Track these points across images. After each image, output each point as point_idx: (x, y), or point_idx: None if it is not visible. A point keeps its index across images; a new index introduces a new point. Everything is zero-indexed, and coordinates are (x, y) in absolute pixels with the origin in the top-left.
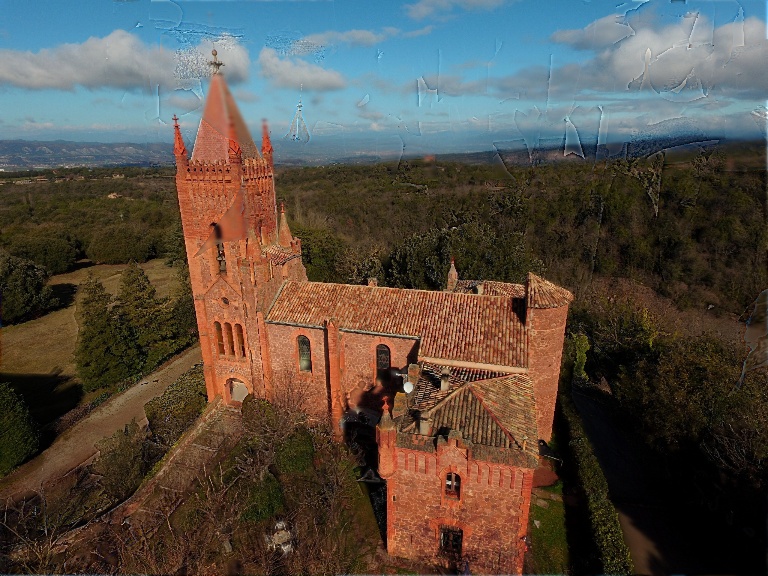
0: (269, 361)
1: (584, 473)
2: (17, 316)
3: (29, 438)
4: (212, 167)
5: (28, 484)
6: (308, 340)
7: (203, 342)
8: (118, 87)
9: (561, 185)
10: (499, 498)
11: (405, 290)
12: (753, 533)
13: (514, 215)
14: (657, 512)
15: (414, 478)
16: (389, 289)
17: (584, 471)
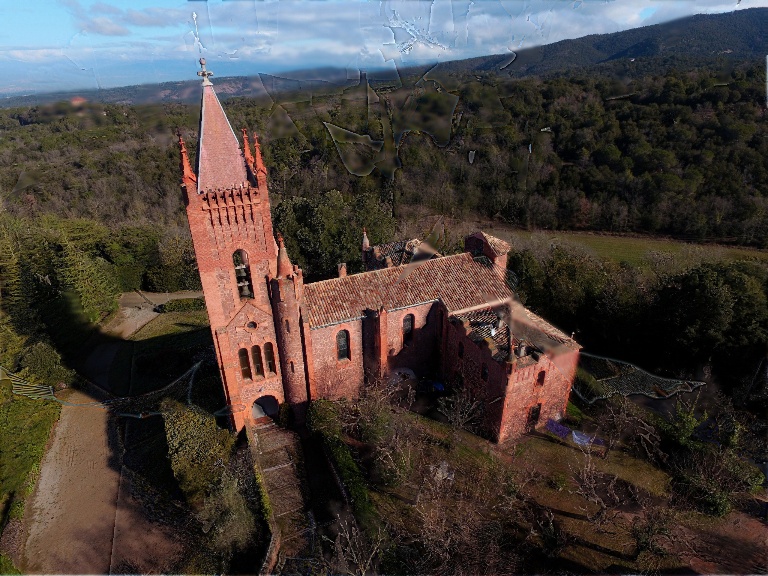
0: None
1: None
2: None
3: None
4: (236, 192)
5: None
6: (345, 332)
7: (228, 374)
8: None
9: None
10: None
11: (401, 267)
12: None
13: (310, 173)
14: None
15: (521, 386)
16: (389, 269)
17: None
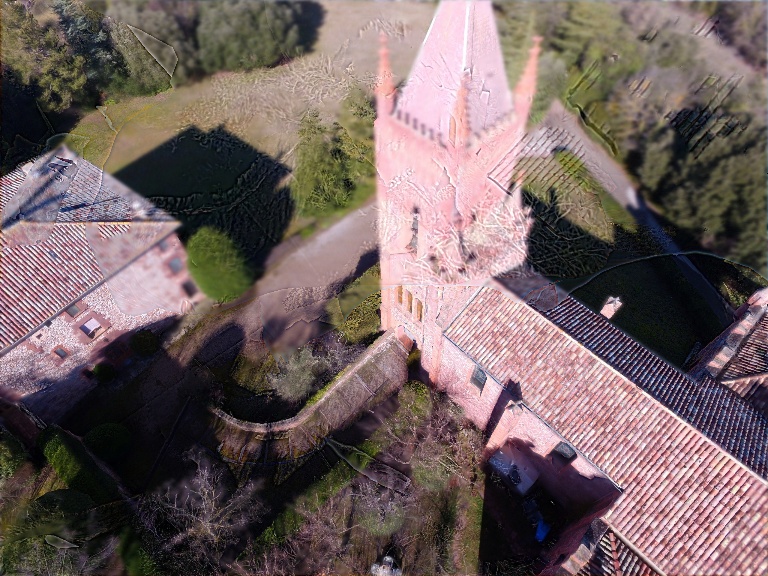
0: (439, 358)
1: None
2: None
3: None
4: None
5: (242, 320)
6: None
7: None
8: None
9: None
10: None
11: (644, 395)
12: None
13: None
14: None
15: None
16: (621, 378)
17: None
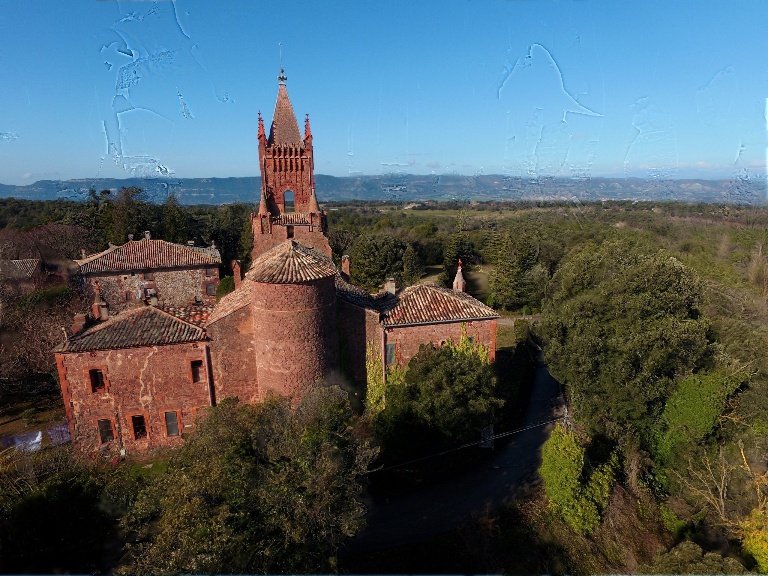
0: None
1: None
2: None
3: None
4: None
5: None
6: None
7: None
8: (421, 112)
9: None
10: None
11: None
12: None
13: None
14: None
15: None
16: None
17: None
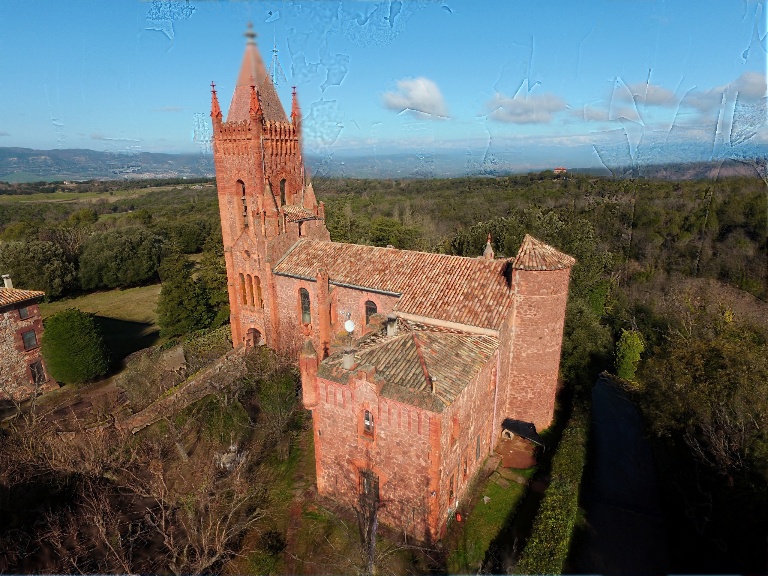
0: (276, 311)
1: (558, 459)
2: (141, 279)
3: (100, 361)
4: (238, 127)
5: None
6: (309, 293)
7: (230, 292)
8: None
9: (667, 180)
10: (409, 444)
11: (404, 251)
12: (725, 547)
13: (609, 213)
14: (648, 522)
15: (334, 412)
16: (389, 250)
17: (559, 457)
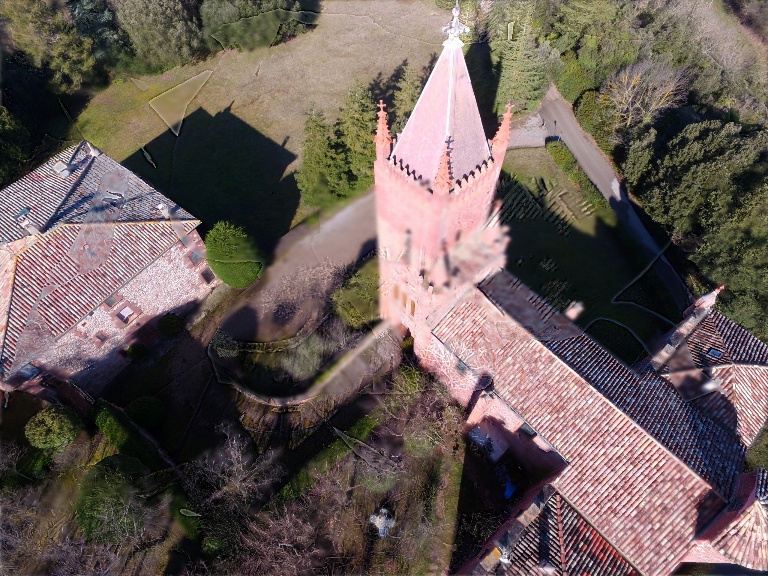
0: None
1: None
2: None
3: (257, 268)
4: None
5: None
6: None
7: None
8: None
9: None
10: None
11: (591, 388)
12: None
13: None
14: None
15: None
16: (574, 374)
17: None
